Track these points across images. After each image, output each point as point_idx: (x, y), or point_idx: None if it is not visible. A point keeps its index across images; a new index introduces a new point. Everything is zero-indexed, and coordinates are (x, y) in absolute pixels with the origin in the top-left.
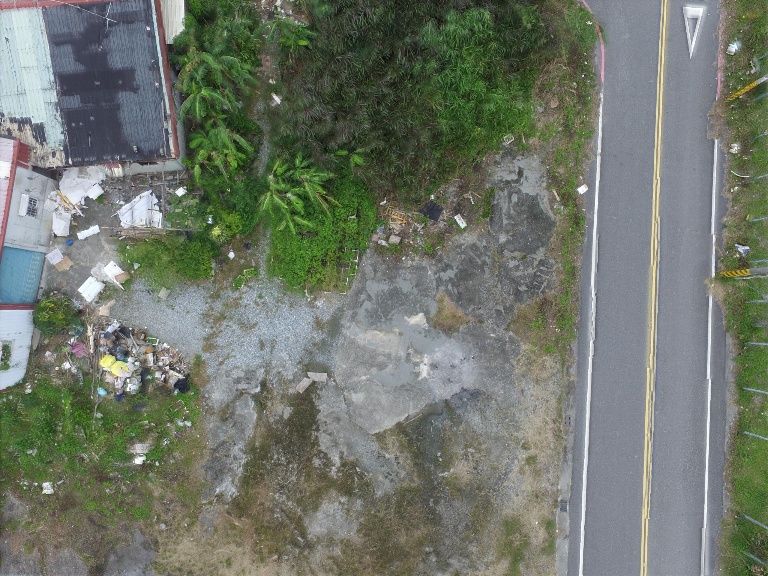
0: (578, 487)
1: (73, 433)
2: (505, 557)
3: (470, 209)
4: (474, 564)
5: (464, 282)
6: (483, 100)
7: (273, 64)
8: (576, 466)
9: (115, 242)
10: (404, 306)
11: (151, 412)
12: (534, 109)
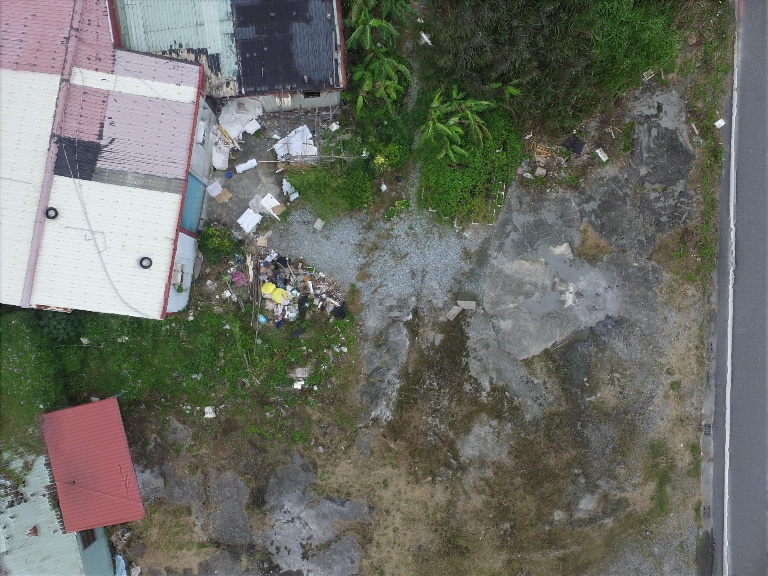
0: (721, 411)
1: (235, 358)
2: (652, 478)
3: (611, 143)
4: (622, 485)
5: (607, 213)
6: (636, 32)
7: (421, 4)
8: (719, 391)
9: (271, 175)
10: (550, 236)
11: (308, 339)
12: None
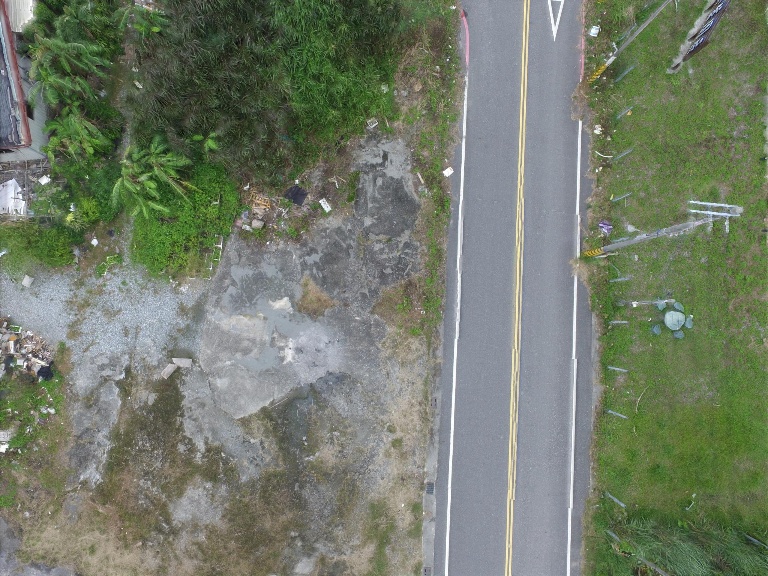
0: (444, 469)
1: None
2: (371, 540)
3: (335, 193)
4: (339, 548)
5: (329, 266)
6: (333, 83)
7: None
8: (442, 448)
9: None
10: (269, 290)
11: (15, 400)
12: (398, 93)
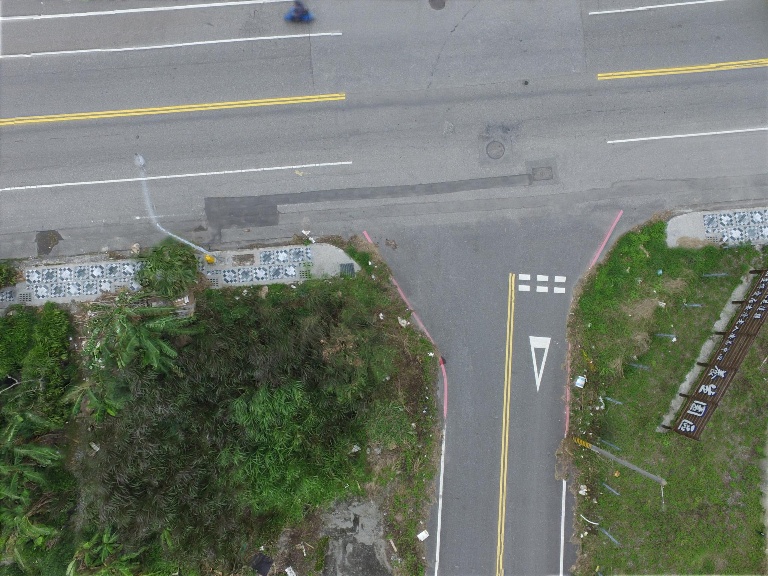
0: None
1: None
2: None
3: (302, 561)
4: None
5: None
6: (299, 478)
7: (93, 409)
8: None
9: None
10: None
11: None
12: (371, 451)
